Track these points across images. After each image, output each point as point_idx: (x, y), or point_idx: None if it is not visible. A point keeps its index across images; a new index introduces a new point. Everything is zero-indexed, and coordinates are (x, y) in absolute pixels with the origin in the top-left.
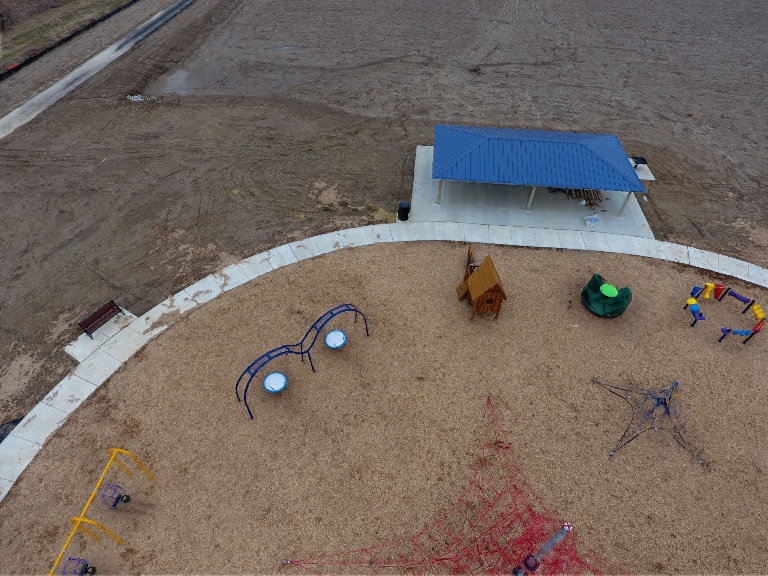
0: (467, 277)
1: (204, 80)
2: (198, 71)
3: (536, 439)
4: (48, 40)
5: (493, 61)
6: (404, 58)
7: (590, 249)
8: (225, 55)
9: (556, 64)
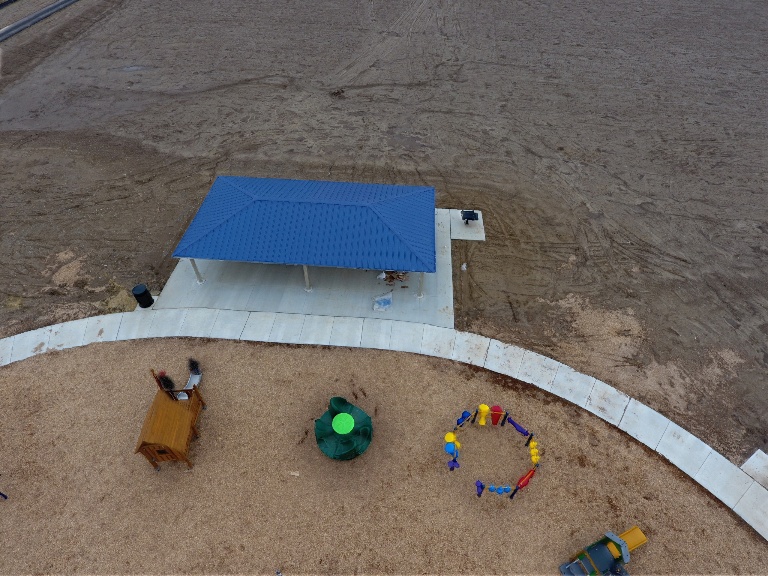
0: None
1: (16, 110)
2: (15, 99)
3: None
4: None
5: (362, 82)
6: (262, 79)
7: (365, 346)
8: (58, 78)
9: (432, 85)
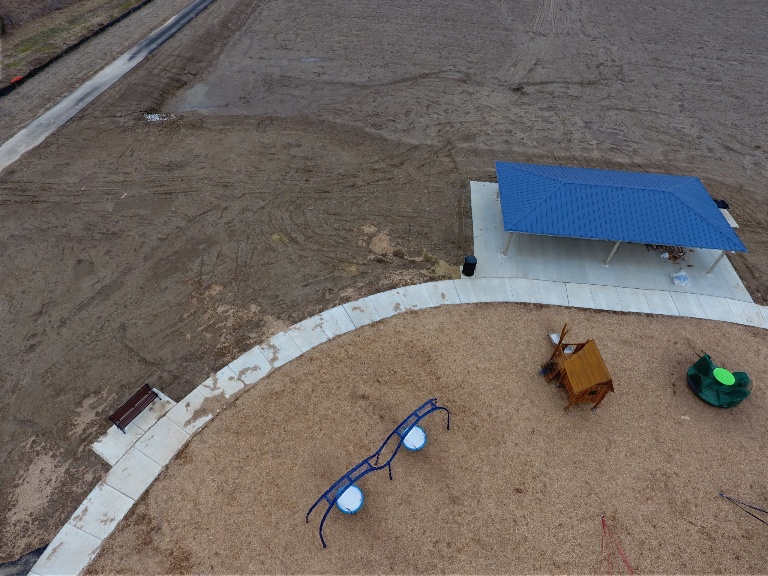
0: (557, 356)
1: (226, 96)
2: (219, 85)
3: None
4: (53, 47)
5: (536, 79)
6: (440, 74)
7: (684, 315)
8: (246, 67)
9: (603, 84)
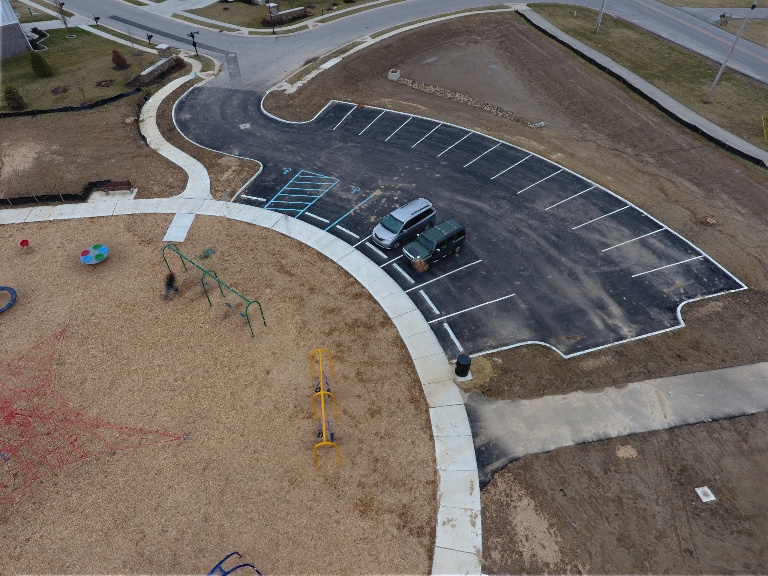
0: None
1: None
2: None
3: None
4: None
5: None
6: None
7: None
8: None
9: None
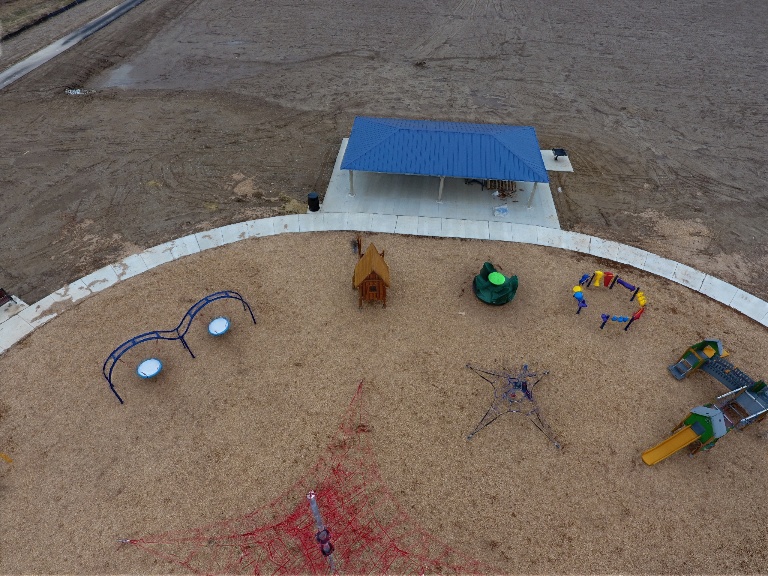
0: None
1: (147, 74)
2: (143, 65)
3: (399, 423)
4: None
5: (439, 55)
6: (351, 52)
7: (493, 239)
8: (173, 50)
9: (502, 58)
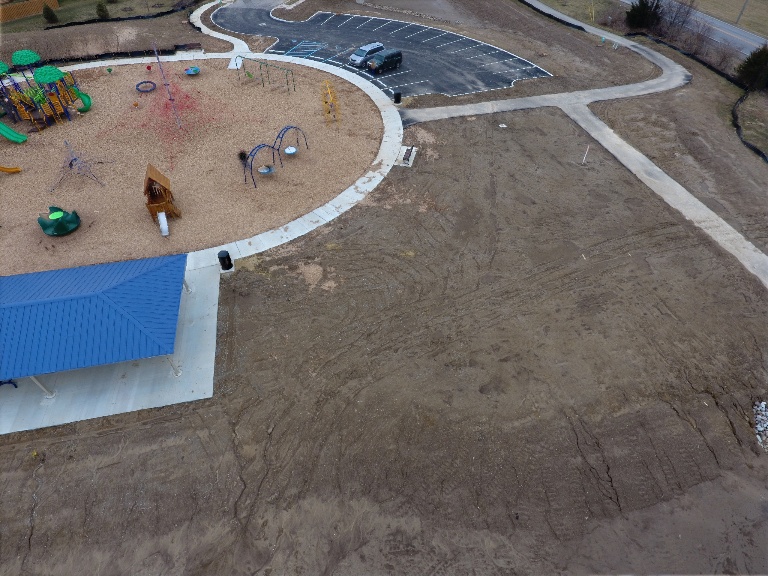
0: None
1: None
2: None
3: None
4: None
5: None
6: None
7: None
8: None
9: None
